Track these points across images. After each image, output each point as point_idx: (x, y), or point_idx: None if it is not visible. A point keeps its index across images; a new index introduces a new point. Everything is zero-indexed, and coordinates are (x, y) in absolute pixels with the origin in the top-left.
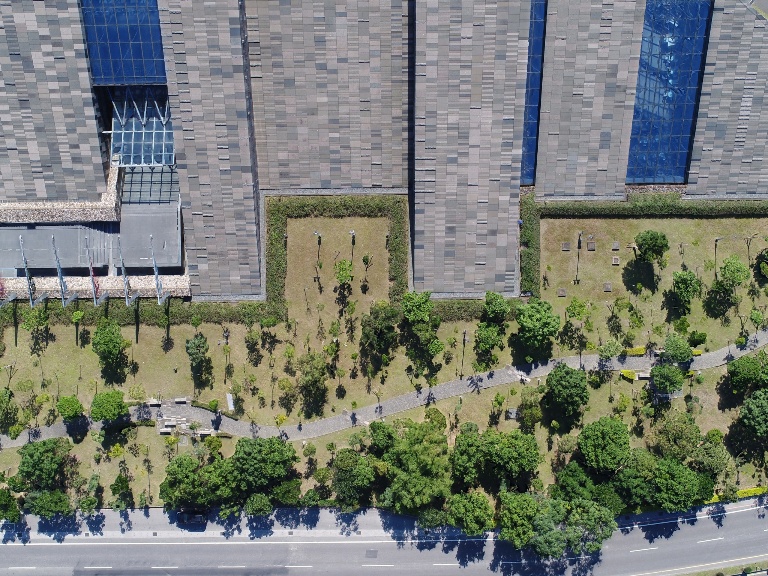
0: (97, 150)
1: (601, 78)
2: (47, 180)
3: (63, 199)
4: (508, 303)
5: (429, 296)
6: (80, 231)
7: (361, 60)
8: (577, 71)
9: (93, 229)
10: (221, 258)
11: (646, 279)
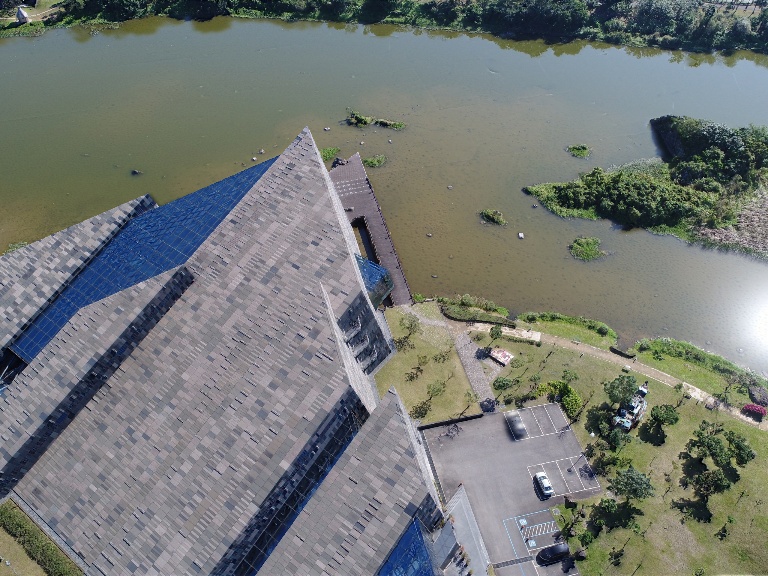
0: None
1: None
2: None
3: None
4: None
5: None
6: None
7: (157, 446)
8: None
9: None
10: None
11: None
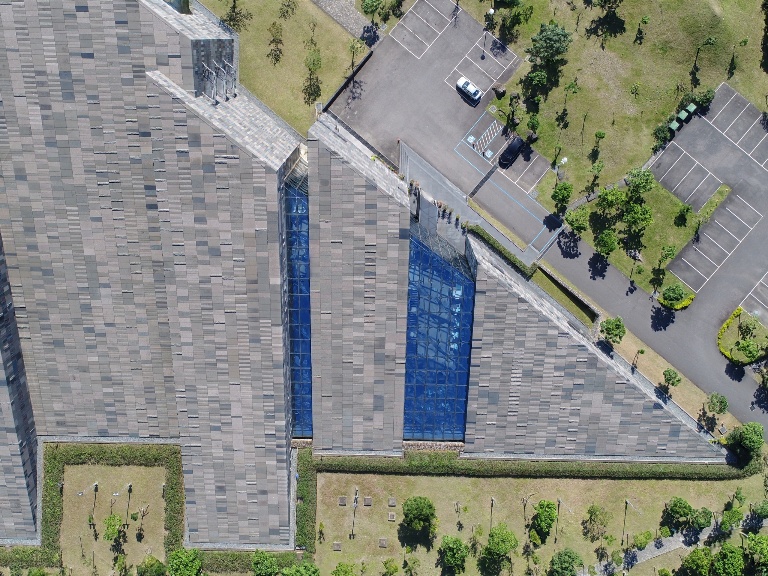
0: None
1: (369, 348)
2: None
3: None
4: (282, 557)
5: (197, 554)
6: None
7: (128, 326)
8: (345, 342)
9: None
10: None
11: (421, 536)
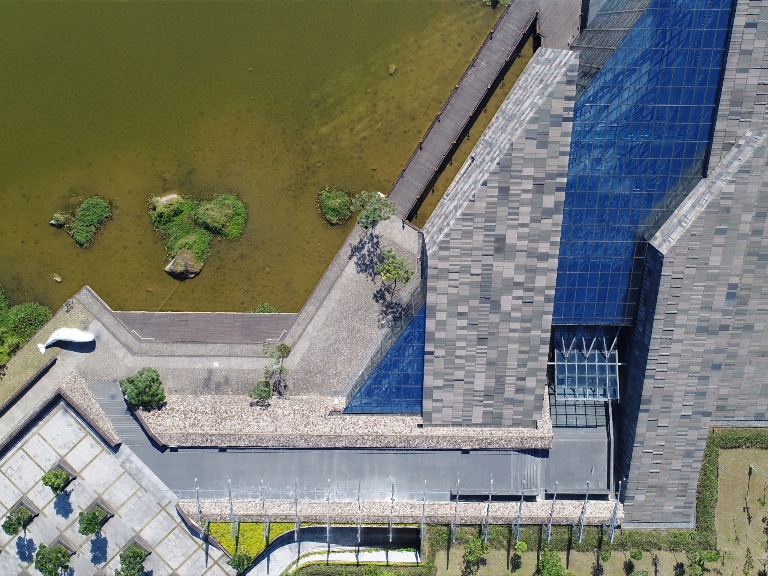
0: (542, 382)
1: None
2: (486, 408)
3: (497, 425)
4: None
5: None
6: (513, 457)
7: None
8: None
9: (524, 454)
10: (659, 490)
11: None
